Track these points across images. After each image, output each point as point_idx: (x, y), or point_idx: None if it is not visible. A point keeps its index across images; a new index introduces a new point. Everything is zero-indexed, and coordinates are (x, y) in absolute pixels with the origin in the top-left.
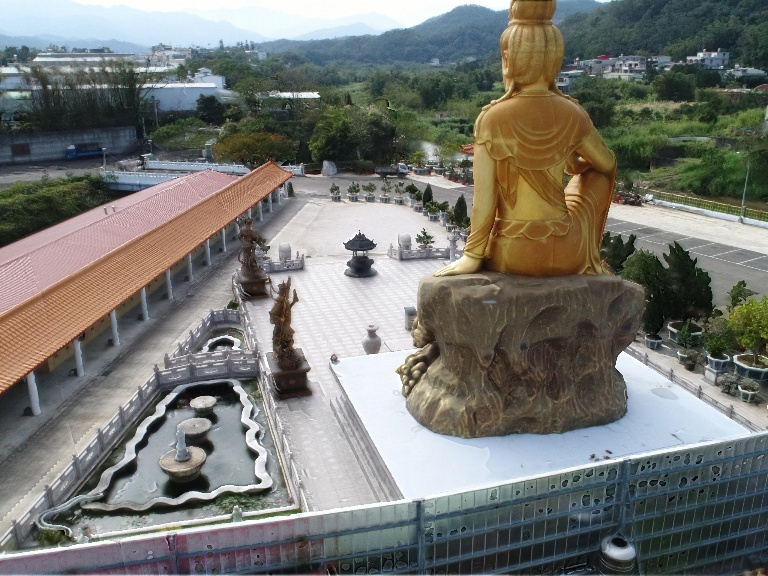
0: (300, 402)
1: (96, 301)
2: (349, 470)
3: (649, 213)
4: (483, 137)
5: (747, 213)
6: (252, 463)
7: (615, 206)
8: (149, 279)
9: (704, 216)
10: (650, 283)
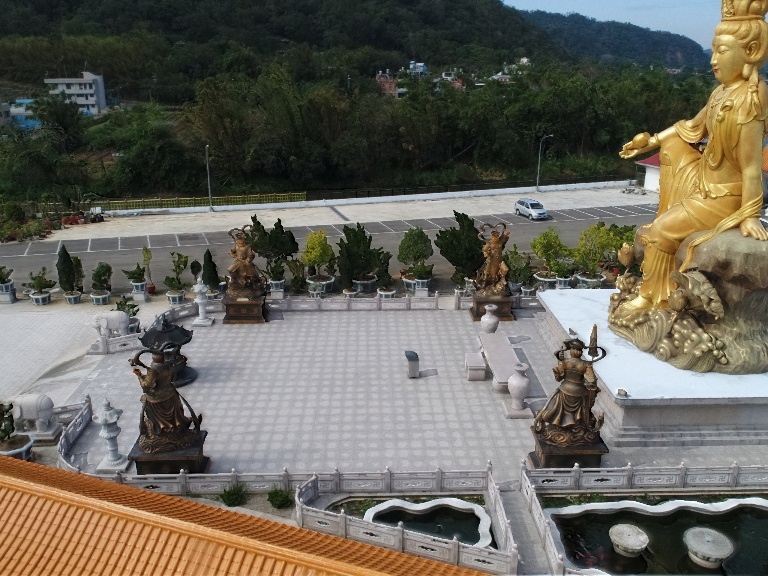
0: (612, 466)
1: (412, 571)
2: (760, 452)
3: (134, 224)
4: (766, 114)
5: (214, 201)
6: (741, 520)
7: (86, 227)
8: (250, 518)
9: (176, 214)
10: (453, 251)
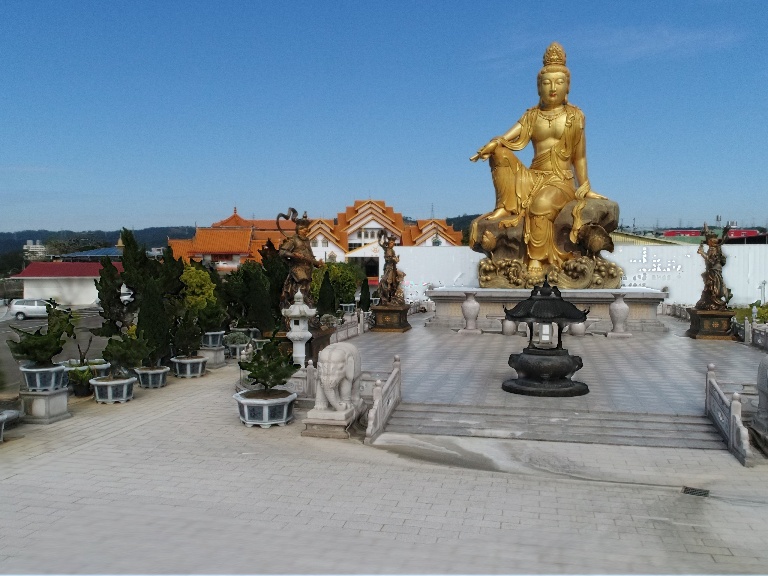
0: None
1: None
2: None
3: None
4: None
5: None
6: None
7: None
8: None
9: None
10: None
